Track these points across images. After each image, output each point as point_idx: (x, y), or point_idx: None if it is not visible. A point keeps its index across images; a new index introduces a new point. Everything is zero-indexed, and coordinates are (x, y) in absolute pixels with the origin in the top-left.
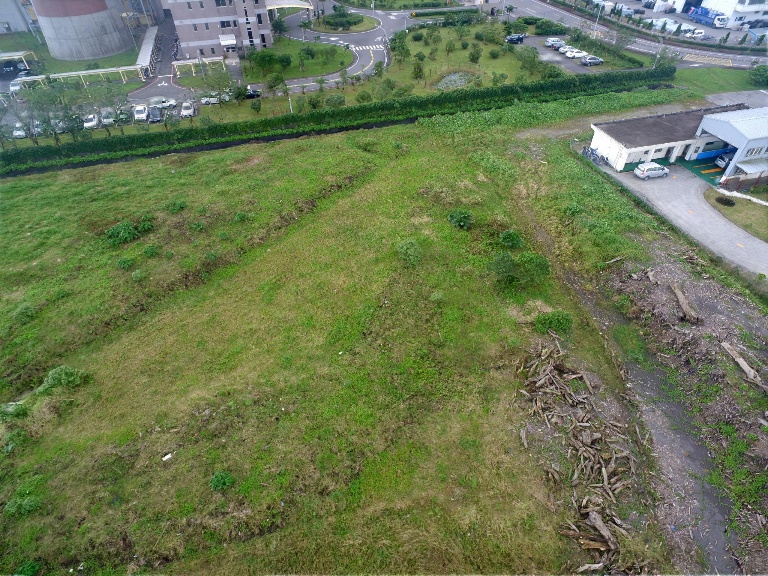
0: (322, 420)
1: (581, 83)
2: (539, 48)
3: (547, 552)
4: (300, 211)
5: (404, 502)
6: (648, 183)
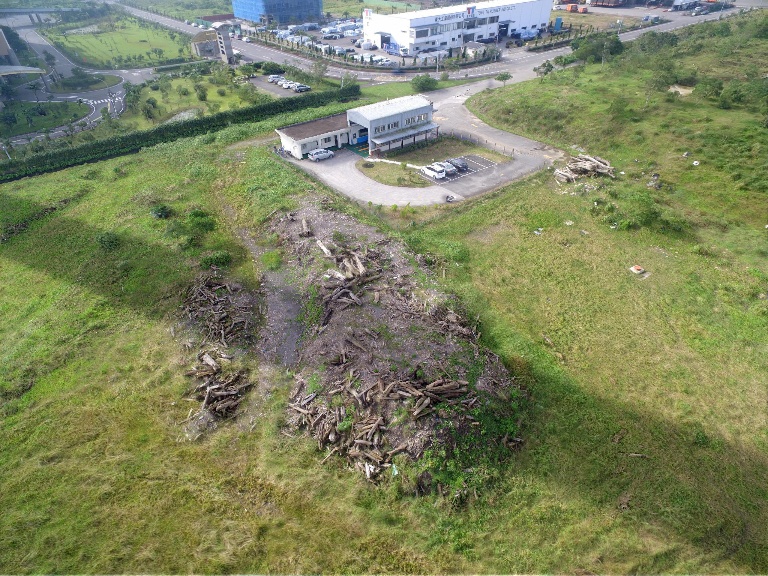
0: (1, 364)
1: (285, 104)
2: (263, 84)
3: (174, 389)
4: (10, 233)
5: (68, 394)
6: (319, 163)
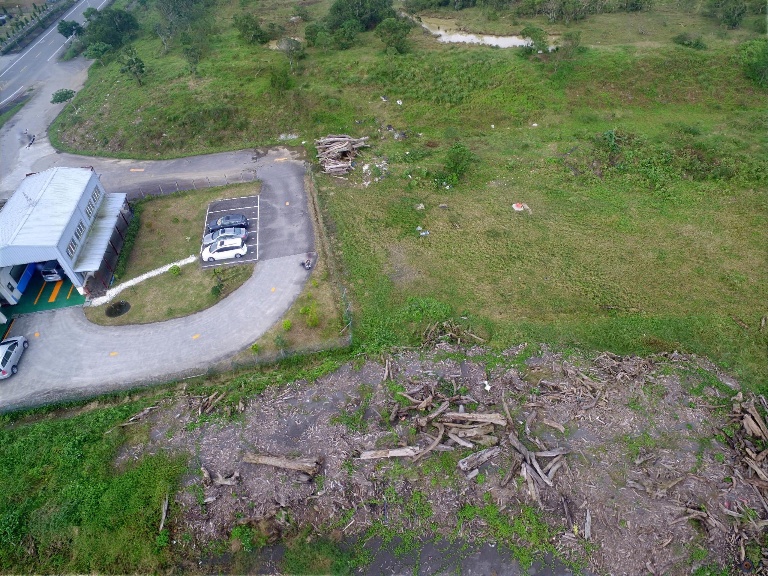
0: None
1: None
2: None
3: None
4: None
5: None
6: (25, 372)
